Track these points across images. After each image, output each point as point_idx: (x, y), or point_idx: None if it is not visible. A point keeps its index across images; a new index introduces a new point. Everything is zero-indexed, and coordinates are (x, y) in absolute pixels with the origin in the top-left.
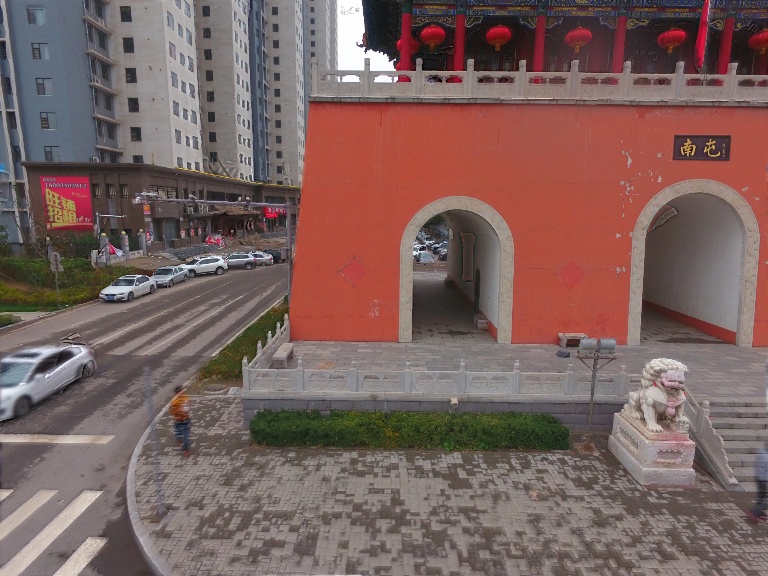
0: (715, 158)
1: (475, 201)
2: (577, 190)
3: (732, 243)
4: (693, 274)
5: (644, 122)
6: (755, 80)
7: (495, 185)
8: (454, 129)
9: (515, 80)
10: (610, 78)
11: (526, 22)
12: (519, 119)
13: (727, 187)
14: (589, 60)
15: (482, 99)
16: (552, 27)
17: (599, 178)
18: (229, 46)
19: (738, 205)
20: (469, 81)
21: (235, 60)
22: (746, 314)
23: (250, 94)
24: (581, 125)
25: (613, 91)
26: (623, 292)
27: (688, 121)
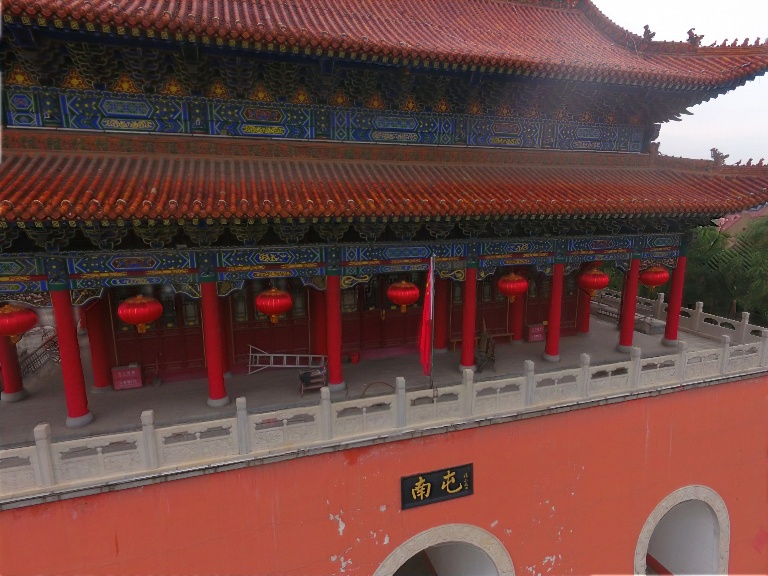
0: (456, 495)
1: None
2: None
3: (488, 570)
4: (457, 563)
5: (358, 468)
6: (496, 387)
7: None
8: (22, 549)
9: (137, 445)
10: (301, 415)
11: (183, 290)
12: (152, 505)
13: (473, 527)
14: (311, 294)
15: (73, 490)
16: (228, 294)
17: (299, 560)
18: None
19: (488, 546)
20: (42, 463)
21: None
22: None
23: None
24: (262, 491)
25: (308, 431)
26: None
27: (417, 455)
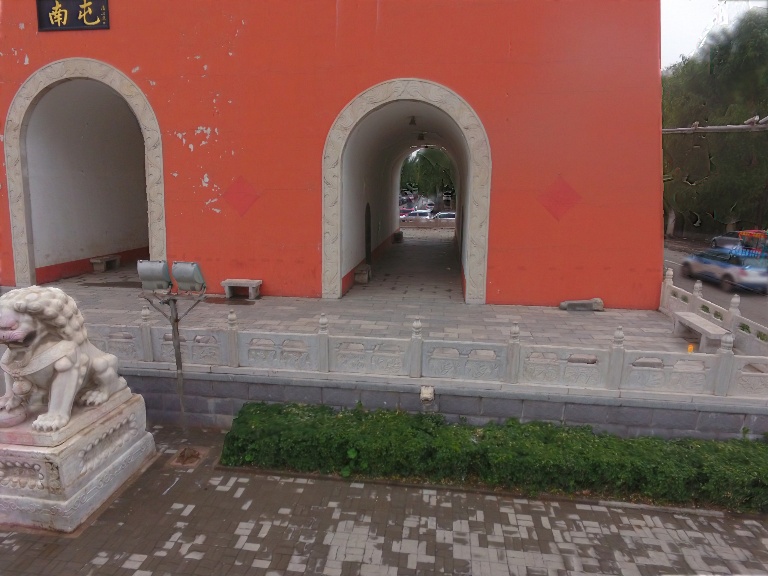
0: (91, 26)
1: None
2: None
3: None
4: None
5: None
6: None
7: None
8: None
9: None
10: None
11: None
12: None
13: (111, 68)
14: None
15: None
16: None
17: None
18: None
19: (128, 93)
20: None
21: None
22: (155, 247)
23: None
24: None
25: None
26: (3, 216)
27: None
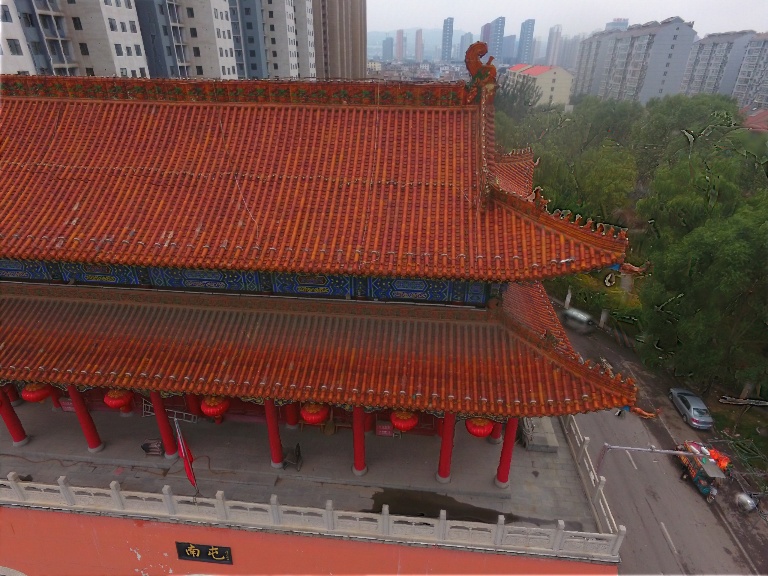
0: (219, 561)
1: (10, 570)
2: (97, 571)
3: None
4: None
5: (144, 529)
6: (245, 507)
7: (23, 560)
8: None
9: (11, 487)
10: (101, 493)
11: (57, 385)
12: (26, 517)
13: None
14: None
15: None
16: (85, 391)
17: (115, 565)
18: (98, 13)
19: None
20: None
21: (110, 28)
22: None
23: (145, 56)
24: (85, 526)
25: (109, 502)
26: None
27: (185, 533)
